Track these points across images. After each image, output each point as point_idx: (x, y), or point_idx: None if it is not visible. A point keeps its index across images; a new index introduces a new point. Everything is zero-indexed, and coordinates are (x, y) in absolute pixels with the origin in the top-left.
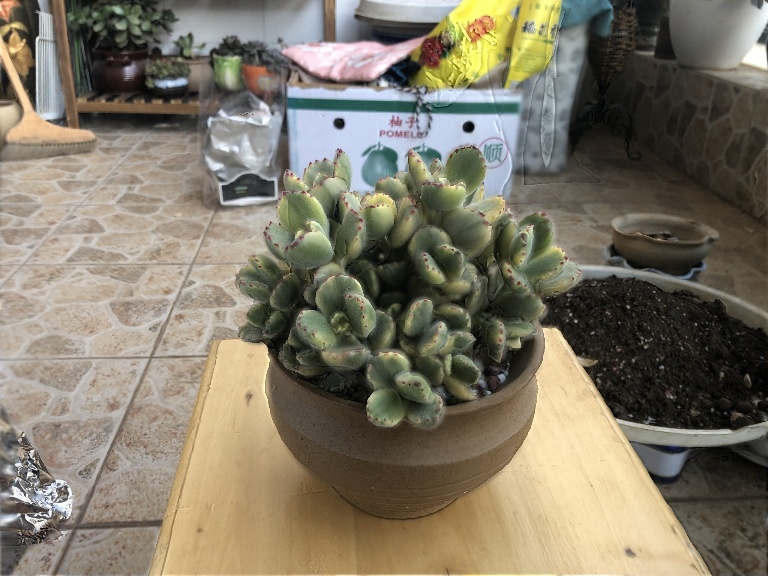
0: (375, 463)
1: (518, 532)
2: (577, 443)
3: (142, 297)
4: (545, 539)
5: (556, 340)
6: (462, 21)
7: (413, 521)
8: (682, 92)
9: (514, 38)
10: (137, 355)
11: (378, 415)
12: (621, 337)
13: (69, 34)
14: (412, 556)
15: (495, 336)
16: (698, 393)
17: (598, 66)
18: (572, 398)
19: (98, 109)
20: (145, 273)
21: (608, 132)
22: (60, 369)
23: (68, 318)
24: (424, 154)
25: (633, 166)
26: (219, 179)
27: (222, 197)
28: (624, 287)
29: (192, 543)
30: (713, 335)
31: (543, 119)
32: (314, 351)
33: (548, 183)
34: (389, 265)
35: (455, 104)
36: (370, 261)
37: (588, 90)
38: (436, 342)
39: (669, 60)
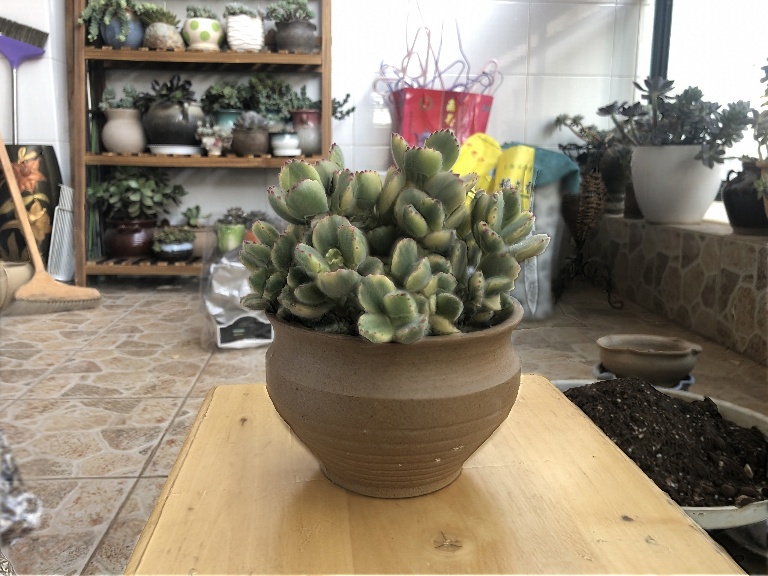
0: (367, 399)
1: (513, 506)
2: (568, 446)
3: (134, 425)
4: (540, 510)
5: (544, 381)
6: None
7: (407, 500)
8: (653, 245)
9: None
10: (125, 475)
11: (369, 329)
12: (615, 429)
13: (86, 206)
14: (406, 523)
15: (475, 280)
16: (699, 481)
17: (573, 223)
18: (561, 417)
19: (105, 272)
20: (139, 405)
21: (589, 284)
22: (44, 488)
23: (57, 444)
24: None
25: (616, 314)
26: (218, 322)
27: (220, 340)
28: (613, 383)
29: (182, 517)
30: (706, 426)
31: (526, 269)
32: (310, 281)
33: (536, 328)
34: (378, 228)
35: None
36: (361, 229)
37: (566, 246)
38: (420, 269)
39: (638, 219)
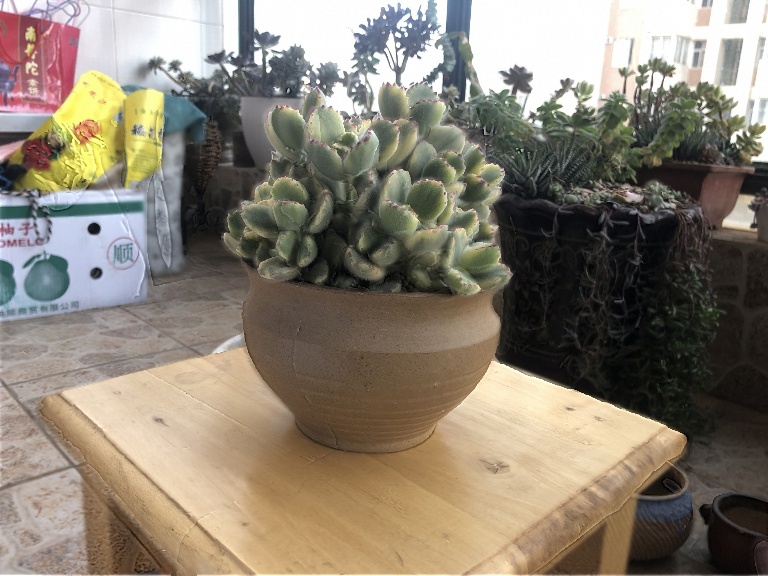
0: (442, 352)
1: (498, 424)
2: None
3: None
4: (518, 421)
5: None
6: (67, 123)
7: (422, 445)
8: None
9: (125, 140)
10: None
11: (469, 282)
12: None
13: None
14: (450, 463)
15: (486, 228)
16: None
17: (193, 173)
18: None
19: None
20: None
21: (212, 232)
22: None
23: None
24: (46, 262)
25: None
26: None
27: None
28: None
29: (251, 535)
30: None
31: (157, 221)
32: (397, 240)
33: (176, 281)
34: None
35: (75, 206)
36: None
37: (186, 196)
38: (478, 221)
39: (247, 168)
